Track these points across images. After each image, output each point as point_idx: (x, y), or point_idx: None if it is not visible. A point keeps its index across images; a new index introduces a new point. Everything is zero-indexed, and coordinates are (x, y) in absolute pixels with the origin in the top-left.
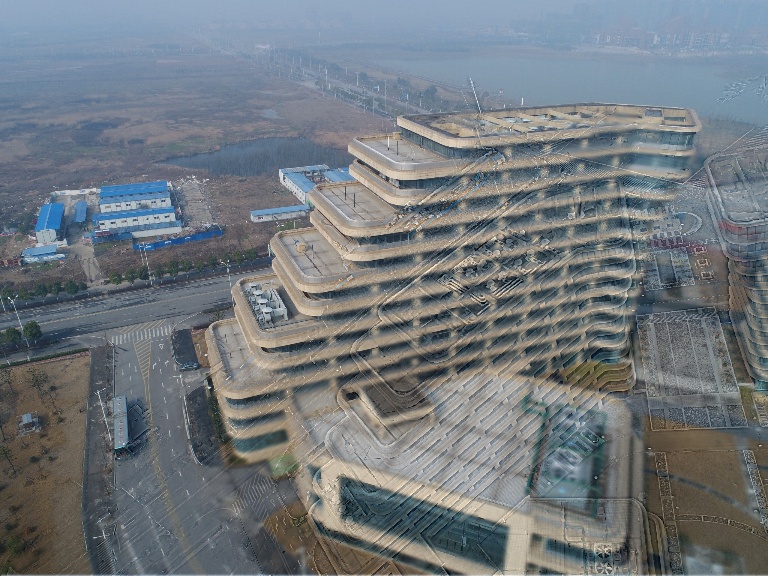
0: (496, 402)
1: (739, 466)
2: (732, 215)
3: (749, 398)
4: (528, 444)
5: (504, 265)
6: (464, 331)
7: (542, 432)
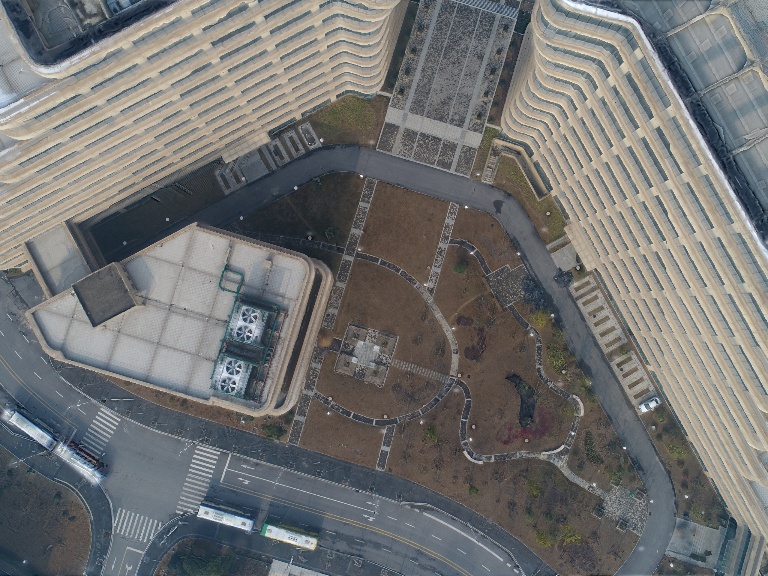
0: (167, 112)
1: (438, 218)
2: None
3: (488, 144)
4: (223, 139)
5: None
6: (98, 32)
7: (245, 128)
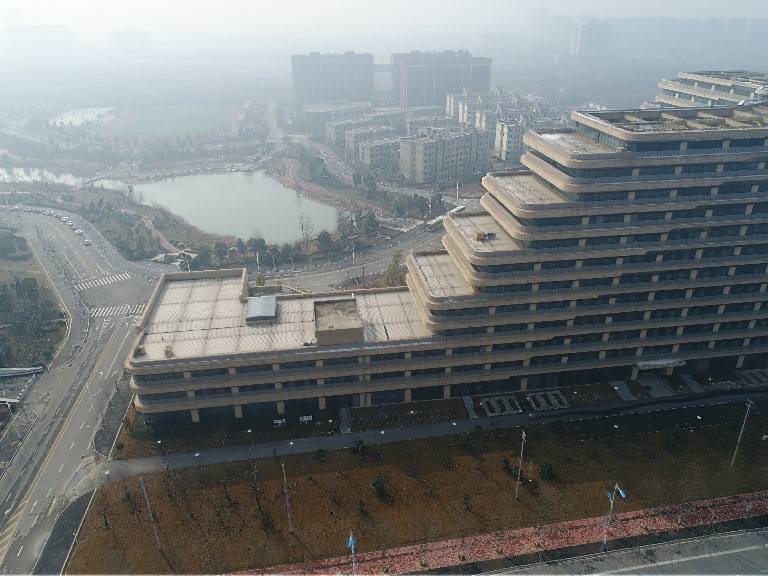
0: None
1: None
2: (761, 101)
3: None
4: None
5: (766, 82)
6: None
7: None
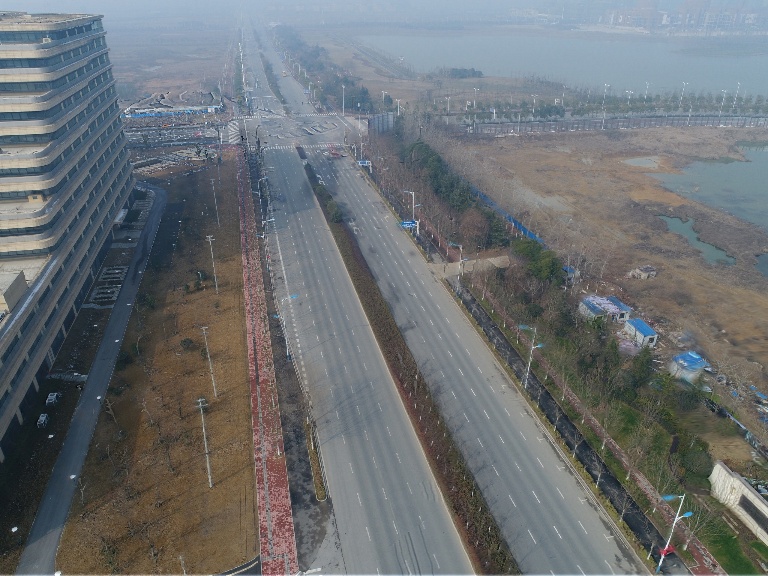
0: None
1: None
2: None
3: None
4: None
5: None
6: None
7: None
